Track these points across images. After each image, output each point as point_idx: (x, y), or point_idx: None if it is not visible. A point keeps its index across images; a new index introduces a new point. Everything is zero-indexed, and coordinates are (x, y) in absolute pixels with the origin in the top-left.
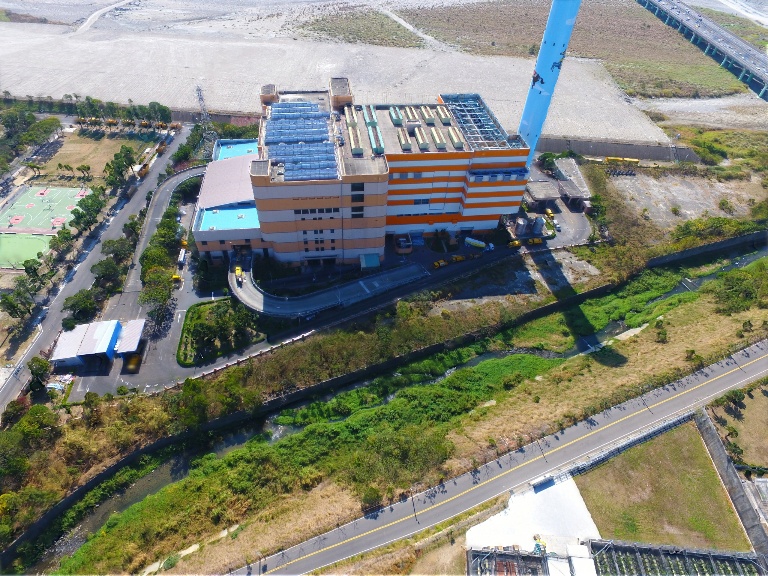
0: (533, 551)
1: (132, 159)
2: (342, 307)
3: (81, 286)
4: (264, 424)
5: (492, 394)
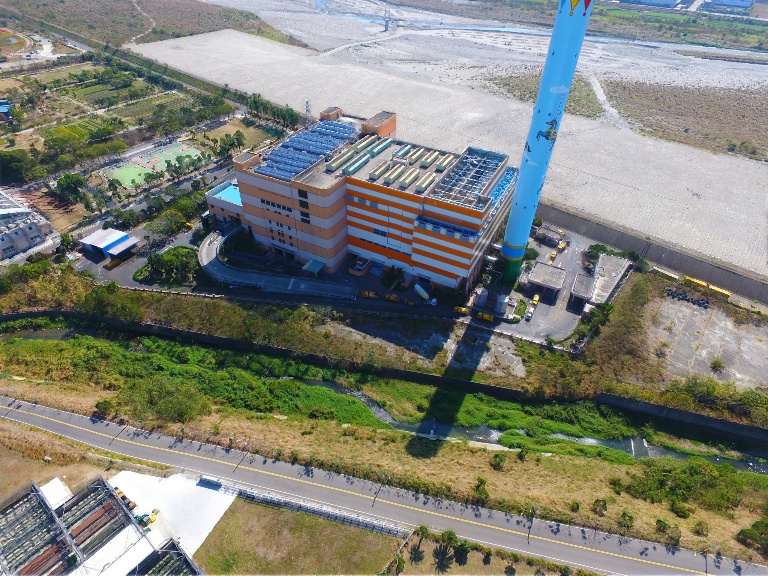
0: (137, 515)
1: (242, 142)
2: (261, 290)
3: (140, 209)
4: (135, 338)
5: (294, 413)
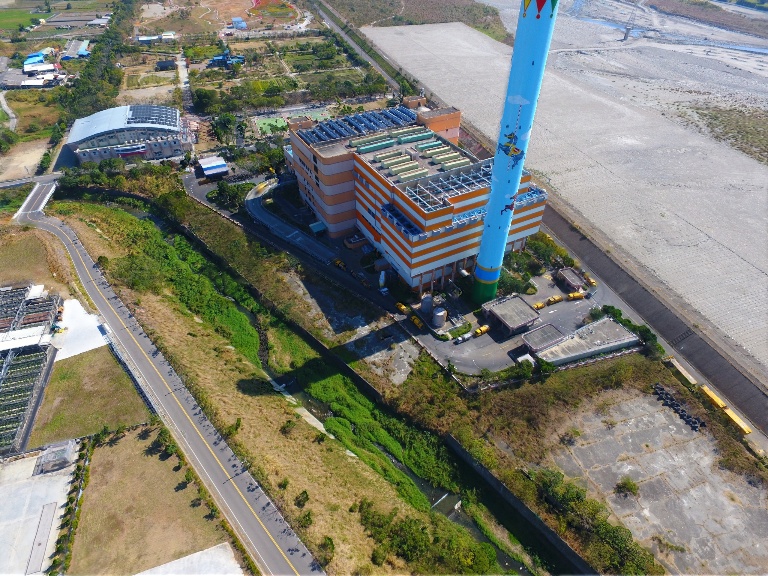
0: None
1: None
2: (270, 231)
3: None
4: (174, 233)
5: (209, 322)
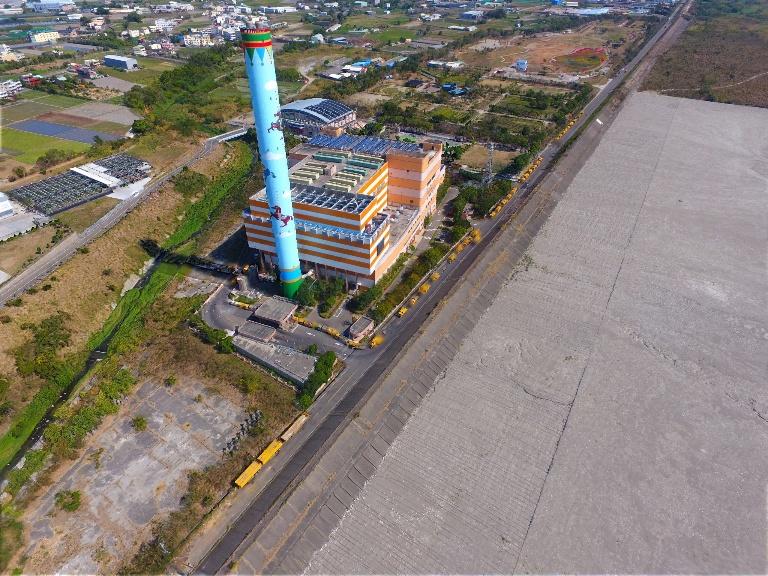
0: None
1: (457, 156)
2: None
3: None
4: None
5: None
